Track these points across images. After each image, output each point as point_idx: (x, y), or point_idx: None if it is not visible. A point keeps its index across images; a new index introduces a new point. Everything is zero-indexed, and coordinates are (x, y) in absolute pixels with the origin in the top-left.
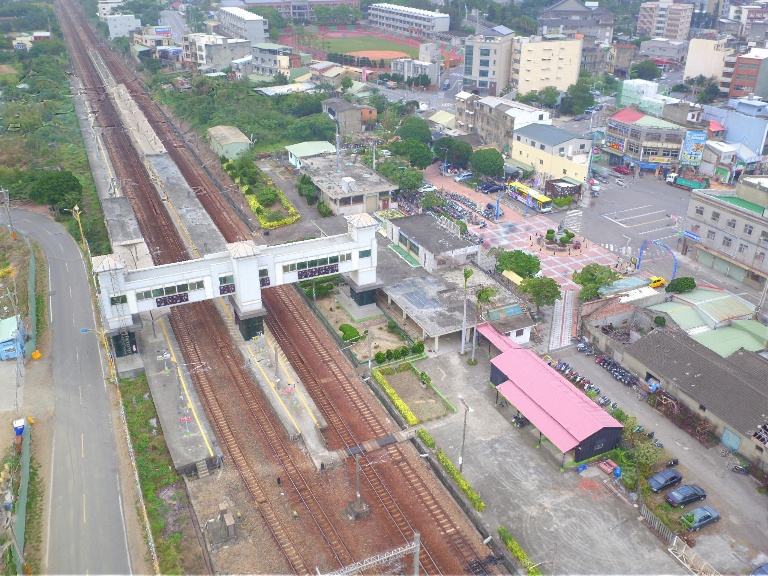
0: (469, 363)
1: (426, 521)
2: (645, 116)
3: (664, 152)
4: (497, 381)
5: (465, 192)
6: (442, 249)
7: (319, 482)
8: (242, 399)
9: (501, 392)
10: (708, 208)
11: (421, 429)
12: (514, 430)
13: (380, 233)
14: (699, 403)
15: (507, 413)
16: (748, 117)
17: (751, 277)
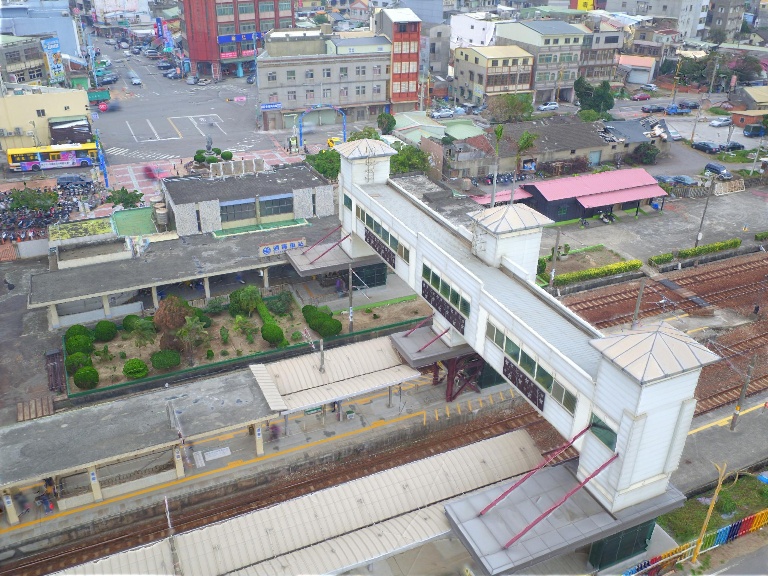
0: None
1: (767, 270)
2: None
3: (30, 74)
4: (557, 215)
5: None
6: (307, 183)
7: (767, 322)
8: None
9: (594, 206)
10: (281, 70)
11: (654, 257)
12: (618, 224)
13: (159, 241)
14: None
15: (592, 224)
16: (46, 19)
17: (342, 114)
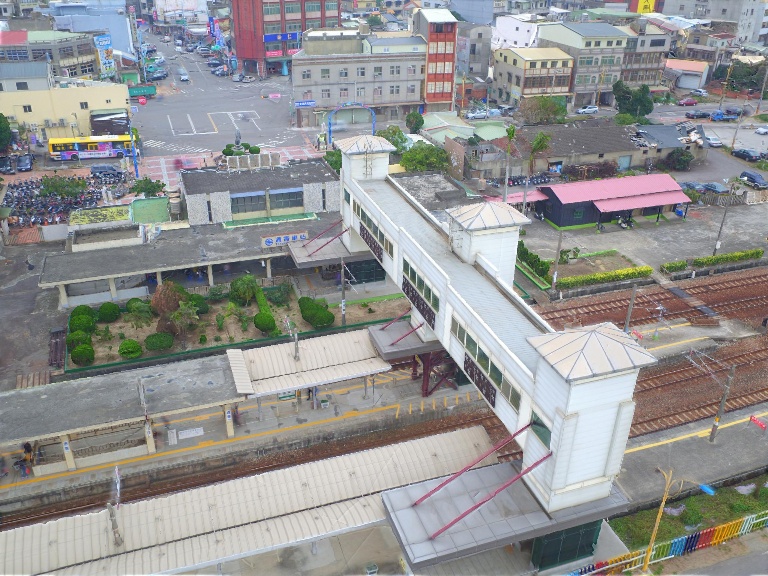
0: (525, 233)
1: None
2: (29, 32)
3: (82, 69)
4: (572, 218)
5: (3, 181)
6: (319, 178)
7: None
8: (640, 395)
9: (610, 210)
10: (316, 68)
11: (666, 265)
12: (636, 230)
13: (171, 229)
14: (599, 153)
15: (609, 229)
16: (101, 16)
17: (375, 113)
